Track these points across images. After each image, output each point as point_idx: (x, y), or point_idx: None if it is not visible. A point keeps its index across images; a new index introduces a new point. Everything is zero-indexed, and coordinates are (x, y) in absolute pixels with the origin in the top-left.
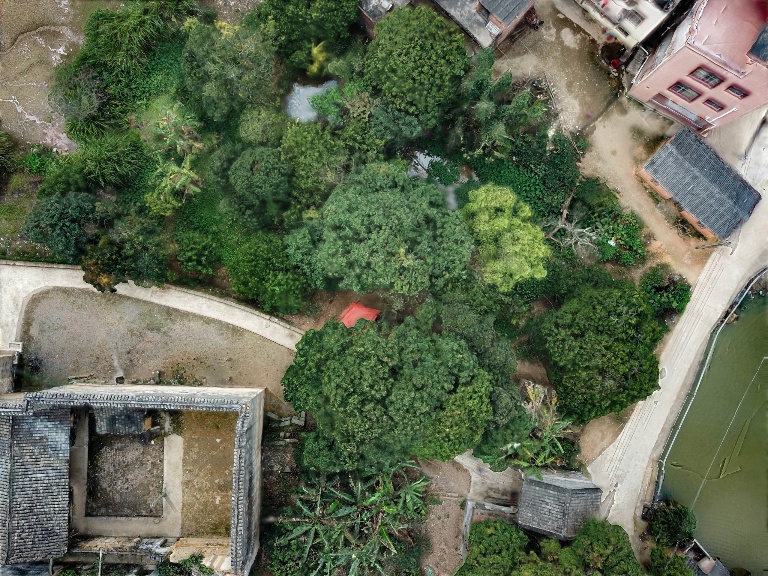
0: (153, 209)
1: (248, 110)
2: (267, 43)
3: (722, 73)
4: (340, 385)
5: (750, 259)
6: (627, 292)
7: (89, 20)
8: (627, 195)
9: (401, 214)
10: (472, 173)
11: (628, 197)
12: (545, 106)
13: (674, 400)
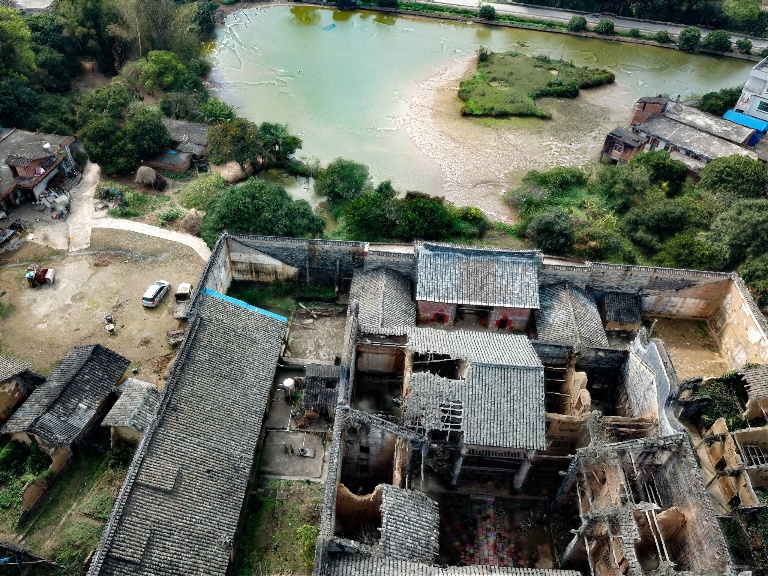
0: None
1: (648, 191)
2: None
3: None
4: None
5: None
6: None
7: (530, 172)
8: None
9: None
10: None
11: None
12: None
13: None
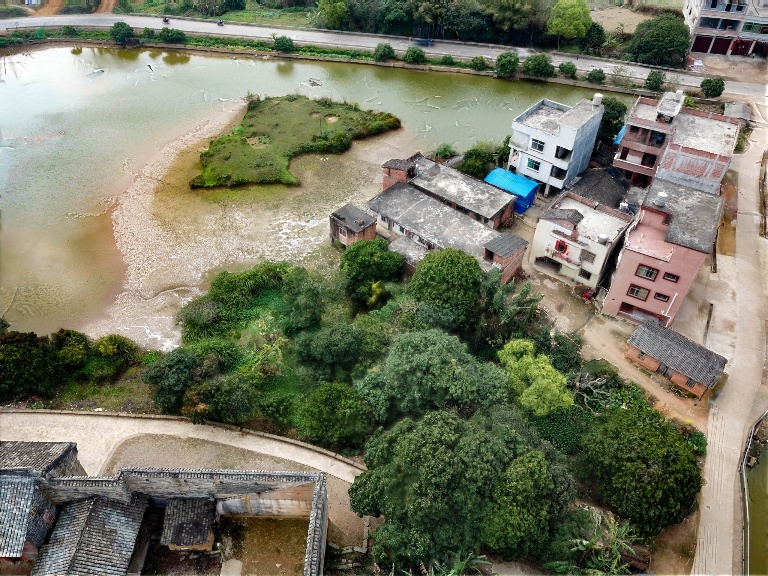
0: (244, 376)
1: (329, 306)
2: (343, 275)
3: (656, 263)
4: (413, 438)
5: (744, 413)
6: (645, 410)
7: (218, 275)
8: (623, 371)
9: (450, 338)
10: (497, 365)
11: (625, 372)
12: (543, 317)
13: (732, 533)
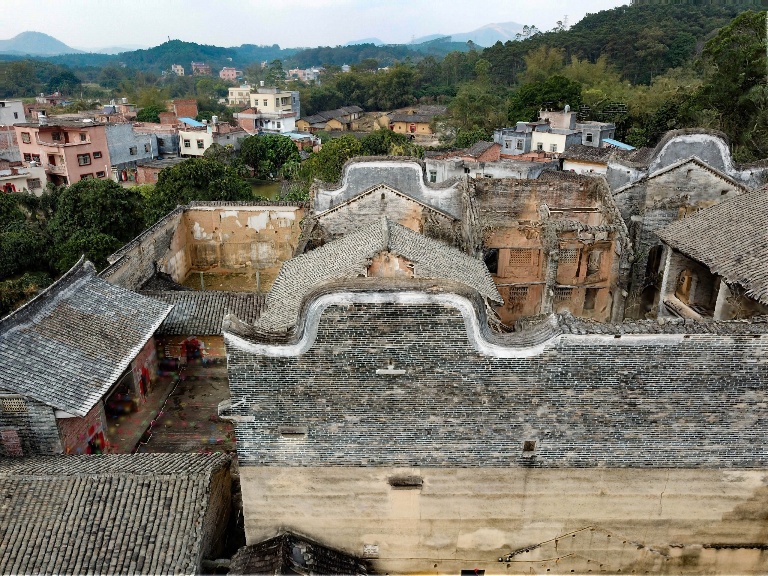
0: None
1: None
2: None
3: (85, 148)
4: (180, 170)
5: None
6: None
7: None
8: None
9: None
10: None
11: None
12: None
13: None
